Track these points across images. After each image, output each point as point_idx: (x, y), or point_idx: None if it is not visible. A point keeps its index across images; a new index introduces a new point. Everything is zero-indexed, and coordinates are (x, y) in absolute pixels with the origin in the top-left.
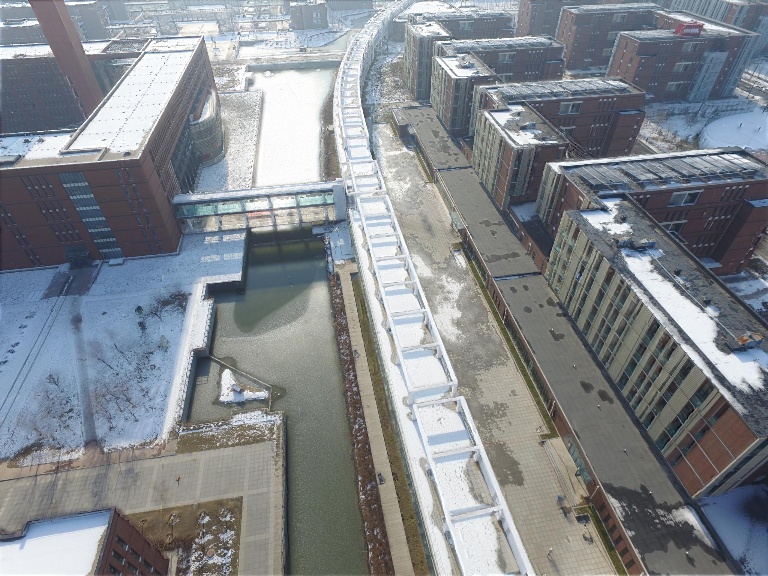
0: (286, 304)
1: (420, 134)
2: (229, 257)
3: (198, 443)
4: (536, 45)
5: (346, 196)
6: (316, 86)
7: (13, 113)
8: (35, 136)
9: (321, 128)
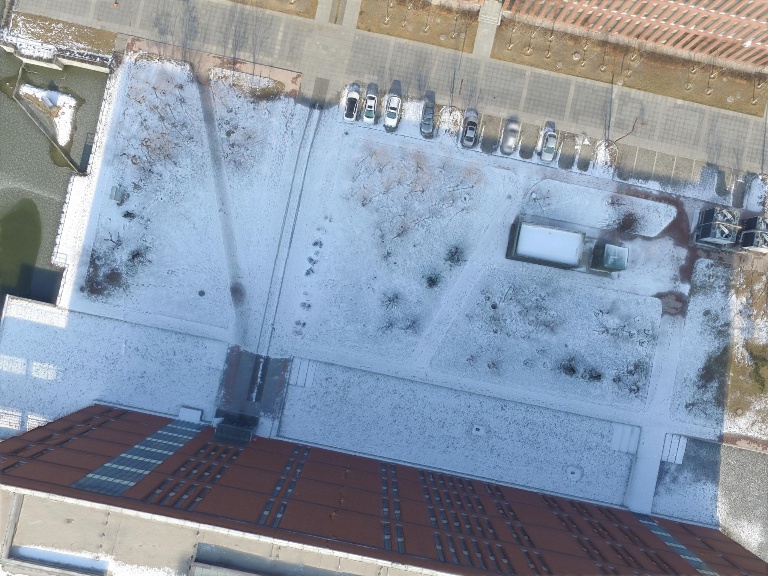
0: None
1: None
2: (18, 363)
3: (93, 38)
4: None
5: None
6: None
7: None
8: None
9: None
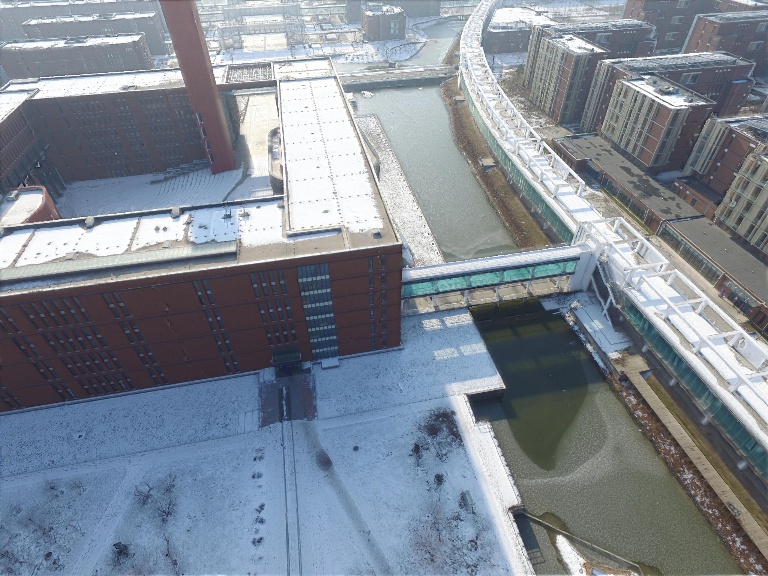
0: (575, 421)
1: (610, 172)
2: (469, 351)
3: None
4: (720, 63)
5: (602, 267)
6: (430, 108)
7: (117, 154)
8: (232, 207)
9: (468, 162)
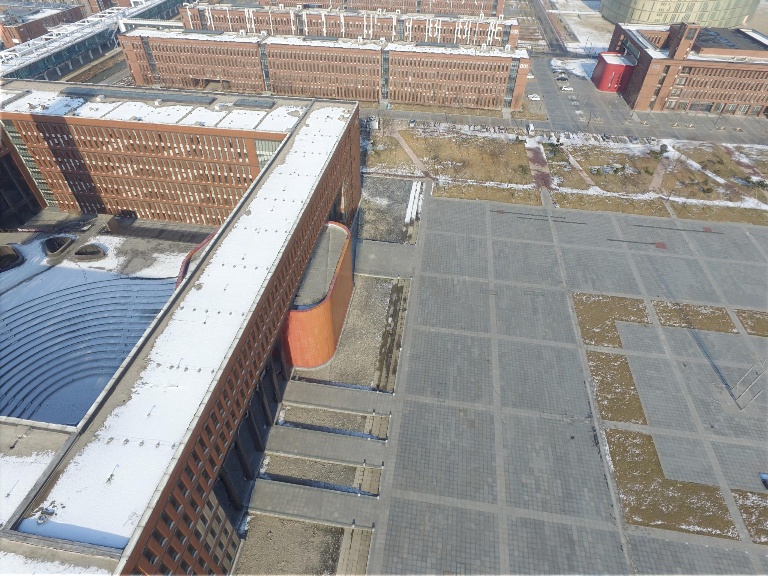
0: None
1: None
2: None
3: None
4: None
5: None
6: None
7: None
8: None
9: None
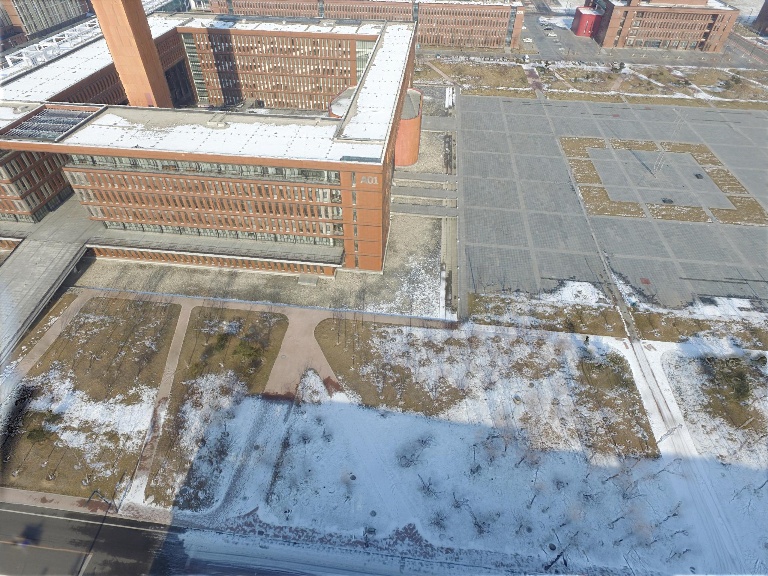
0: None
1: None
2: None
3: None
4: None
5: None
6: None
7: None
8: None
9: None
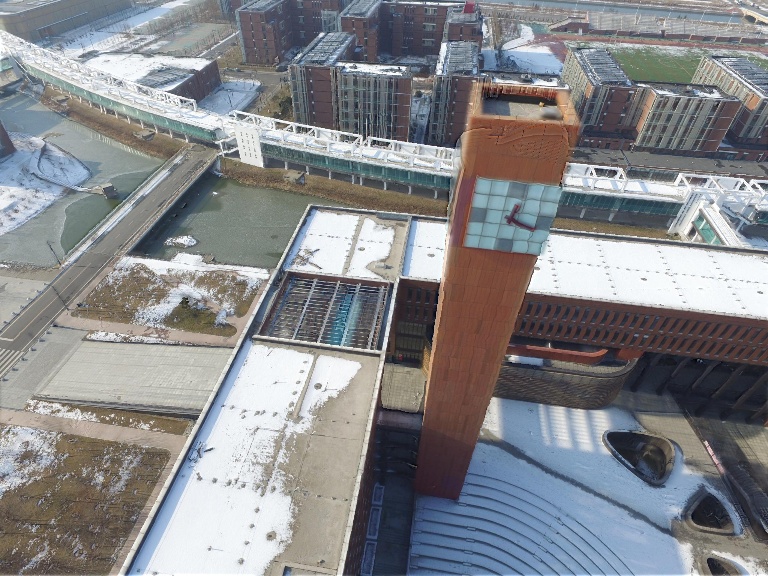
0: None
1: None
2: None
3: None
4: None
5: None
6: (289, 205)
7: None
8: None
9: None
